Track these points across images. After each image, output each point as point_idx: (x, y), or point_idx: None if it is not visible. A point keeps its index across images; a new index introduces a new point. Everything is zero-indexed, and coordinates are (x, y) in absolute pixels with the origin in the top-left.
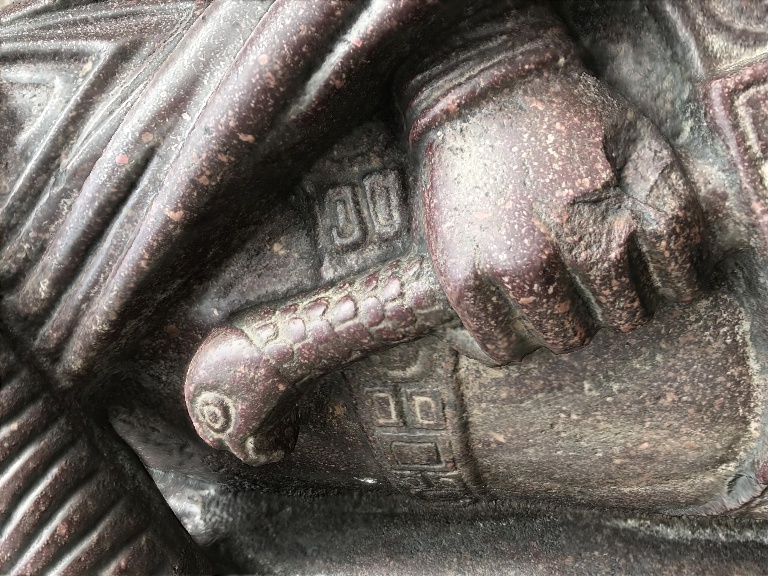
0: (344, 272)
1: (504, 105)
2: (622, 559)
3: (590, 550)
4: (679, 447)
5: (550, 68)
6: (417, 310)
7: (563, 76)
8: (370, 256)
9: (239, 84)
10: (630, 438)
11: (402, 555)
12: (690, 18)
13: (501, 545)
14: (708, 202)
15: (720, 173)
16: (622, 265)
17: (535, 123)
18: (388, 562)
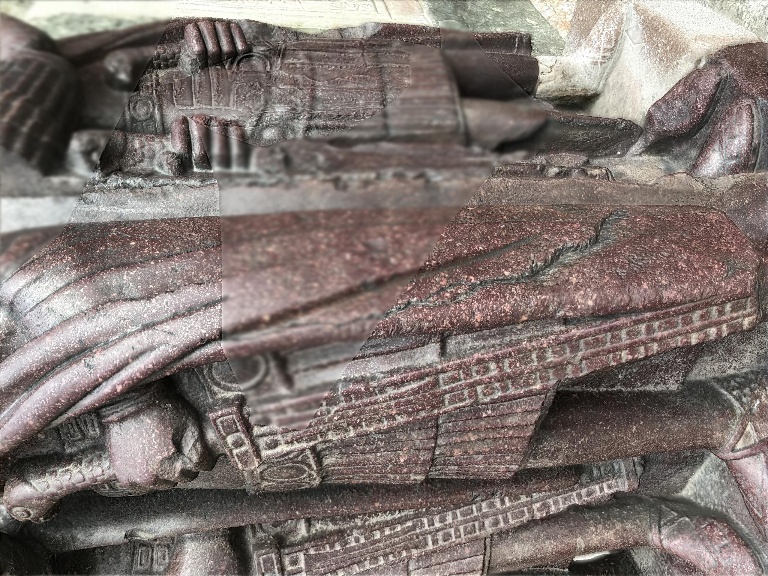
0: (76, 449)
1: (136, 418)
2: (219, 504)
3: (206, 502)
4: (225, 485)
5: (153, 405)
6: (110, 478)
7: (158, 408)
8: (88, 443)
9: (20, 428)
10: (207, 484)
11: (121, 518)
12: (205, 381)
13: (167, 506)
14: (212, 445)
15: (215, 437)
16: (180, 476)
17: (148, 428)
18: (114, 523)
